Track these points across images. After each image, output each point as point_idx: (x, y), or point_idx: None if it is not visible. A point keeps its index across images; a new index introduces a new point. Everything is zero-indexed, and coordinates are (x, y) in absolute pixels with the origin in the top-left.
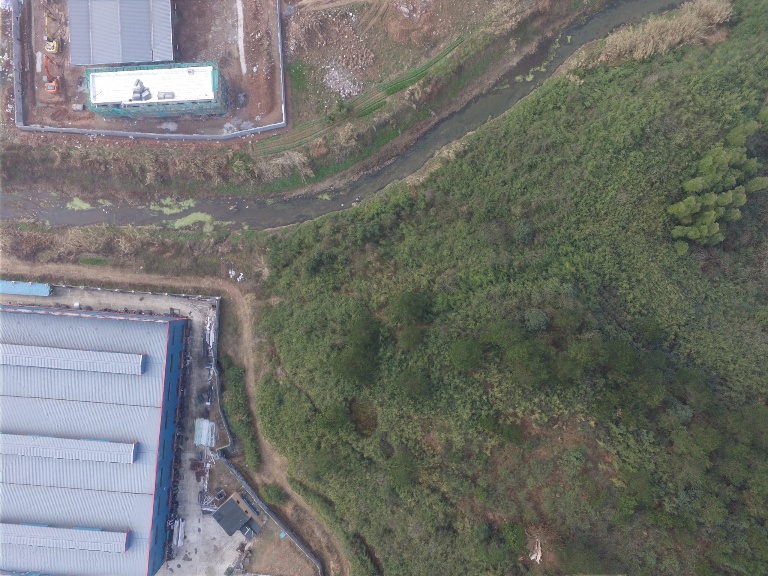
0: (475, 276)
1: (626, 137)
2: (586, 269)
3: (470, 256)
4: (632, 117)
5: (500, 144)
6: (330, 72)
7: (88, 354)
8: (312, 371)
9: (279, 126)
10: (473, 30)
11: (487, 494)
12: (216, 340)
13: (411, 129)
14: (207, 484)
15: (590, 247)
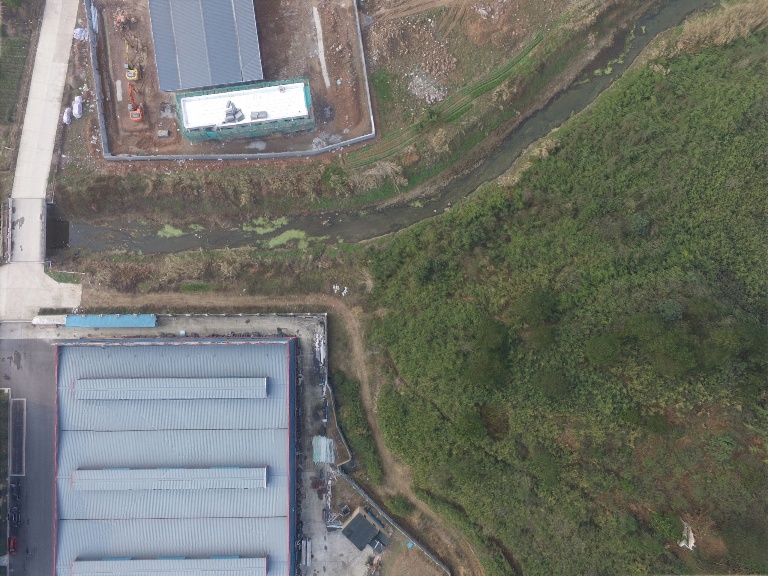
0: (597, 272)
1: (730, 123)
2: (704, 256)
3: (585, 252)
4: (732, 103)
5: (593, 139)
6: (414, 79)
7: (211, 382)
8: (435, 379)
9: (368, 137)
10: (551, 27)
11: (633, 486)
12: (327, 356)
13: (497, 130)
14: (330, 501)
15: (704, 234)
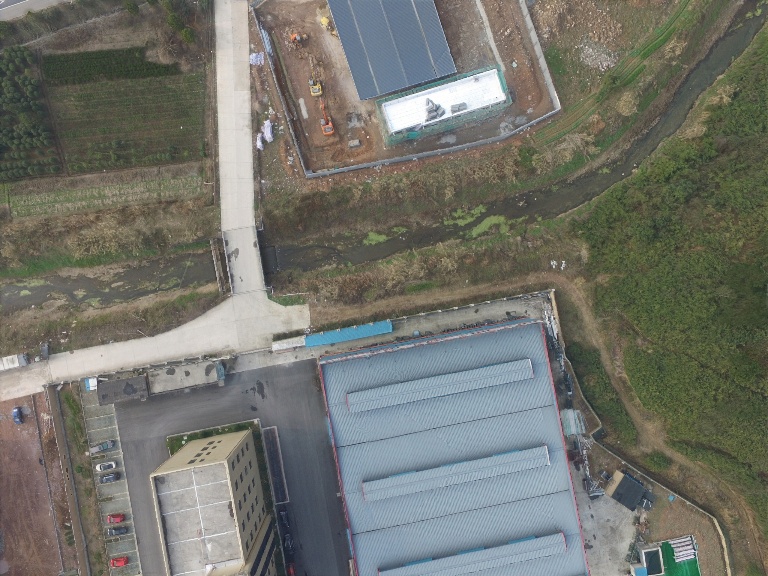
0: None
1: None
2: None
3: None
4: None
5: None
6: (584, 50)
7: (479, 372)
8: (684, 331)
9: (554, 113)
10: None
11: None
12: None
13: (666, 87)
14: (588, 470)
15: None
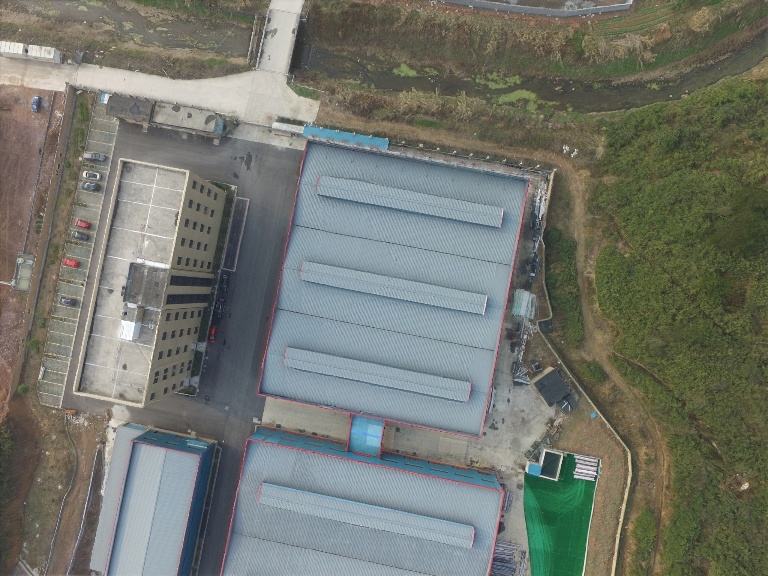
0: None
1: None
2: None
3: None
4: None
5: None
6: None
7: (450, 201)
8: (669, 244)
9: (623, 8)
10: None
11: None
12: None
13: (750, 25)
14: (522, 355)
15: None
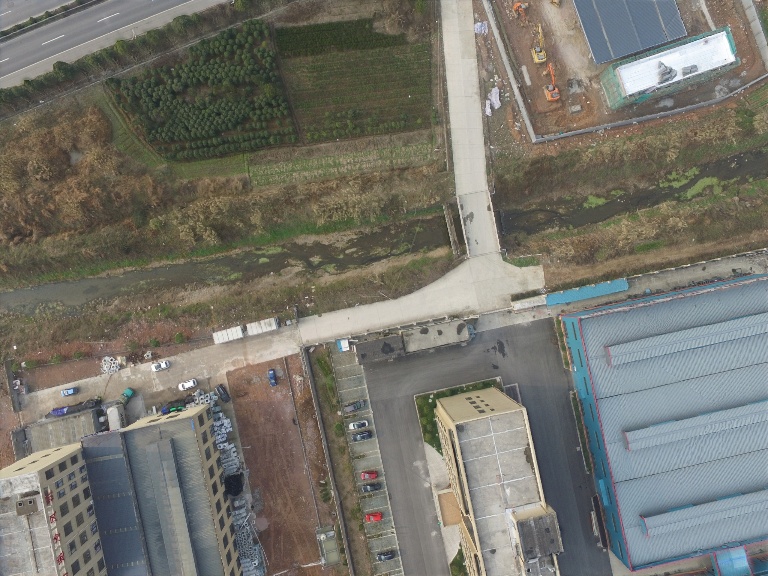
0: None
1: None
2: None
3: None
4: None
5: None
6: None
7: (733, 323)
8: None
9: None
10: None
11: None
12: None
13: None
14: None
15: None
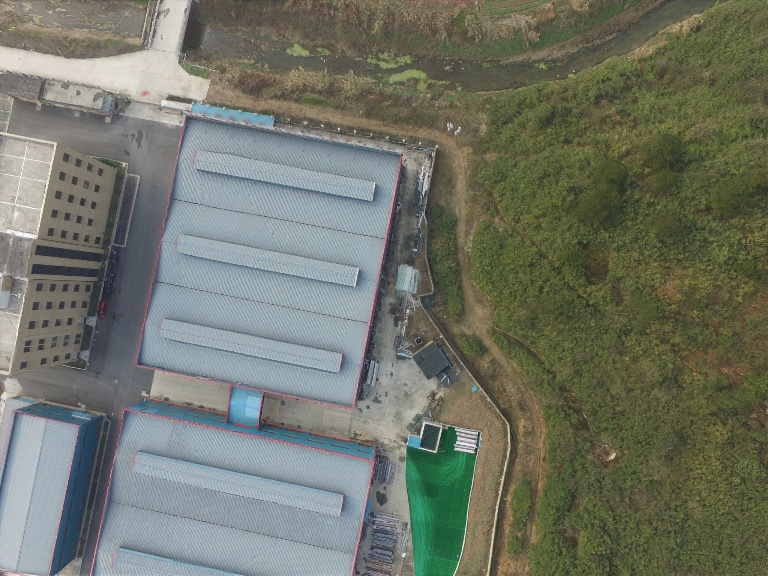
0: (731, 129)
1: None
2: None
3: (719, 114)
4: None
5: (740, 20)
6: None
7: (323, 175)
8: (538, 218)
9: None
10: None
11: None
12: None
13: (636, 6)
14: (405, 329)
15: None
